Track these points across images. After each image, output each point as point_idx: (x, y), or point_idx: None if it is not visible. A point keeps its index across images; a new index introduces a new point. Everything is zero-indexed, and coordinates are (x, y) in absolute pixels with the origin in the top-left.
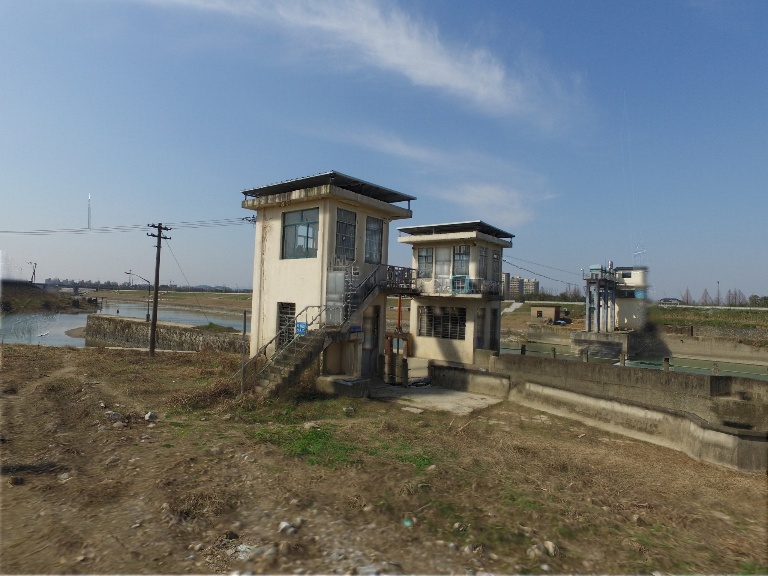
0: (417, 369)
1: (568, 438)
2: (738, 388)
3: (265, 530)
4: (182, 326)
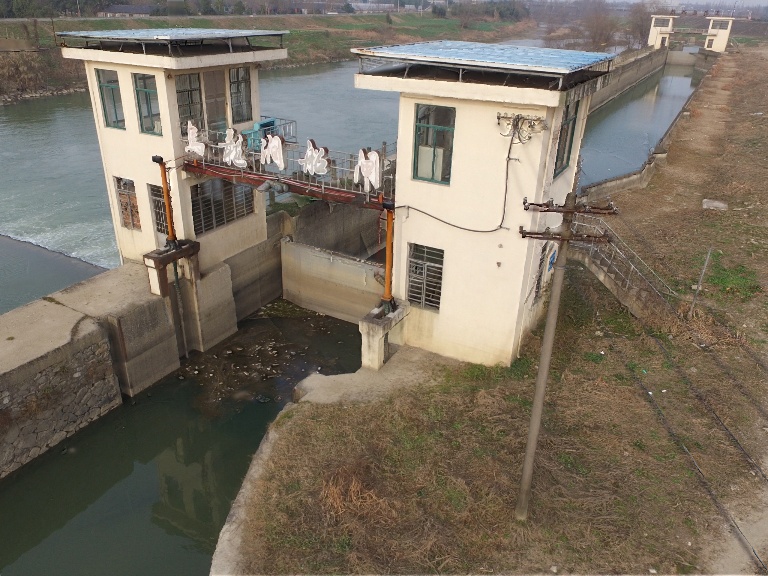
0: (220, 287)
1: None
2: None
3: None
4: None
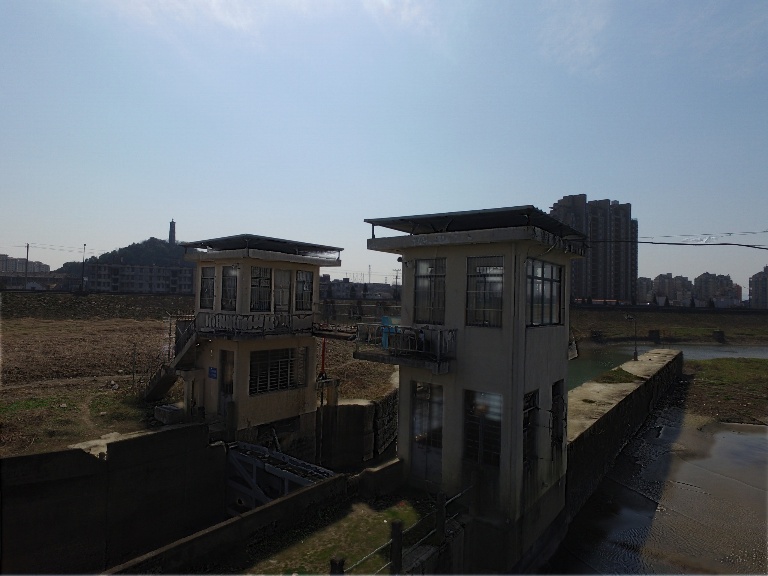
0: None
1: None
2: None
3: None
4: (618, 368)
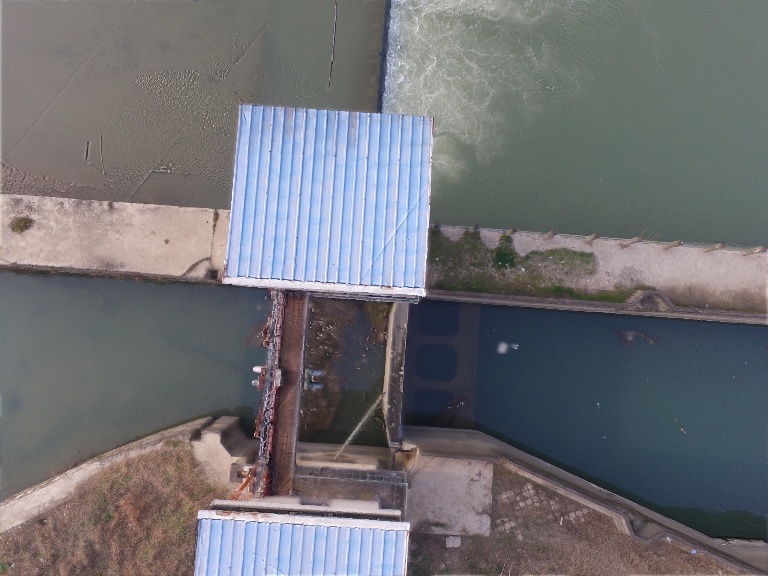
0: None
1: (556, 530)
2: None
3: None
4: None
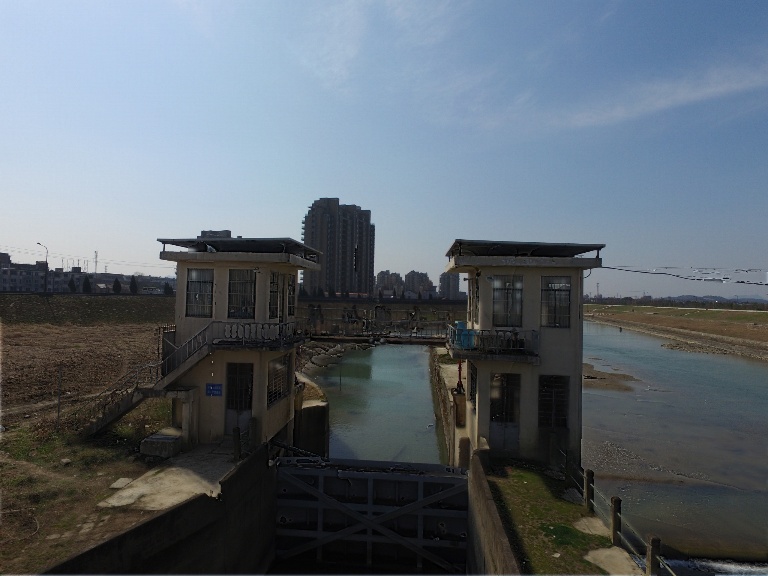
0: (456, 446)
1: None
2: None
3: None
4: (439, 352)
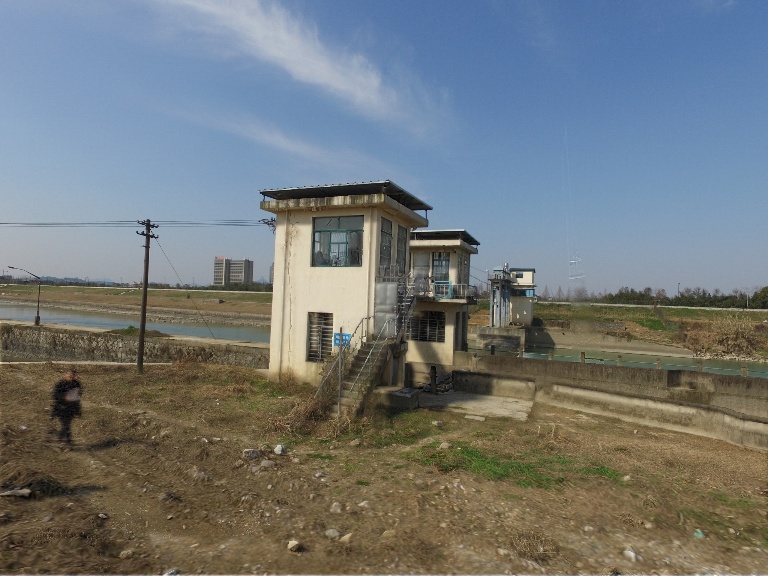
0: None
1: (628, 435)
2: (686, 379)
3: (619, 561)
4: (91, 330)
